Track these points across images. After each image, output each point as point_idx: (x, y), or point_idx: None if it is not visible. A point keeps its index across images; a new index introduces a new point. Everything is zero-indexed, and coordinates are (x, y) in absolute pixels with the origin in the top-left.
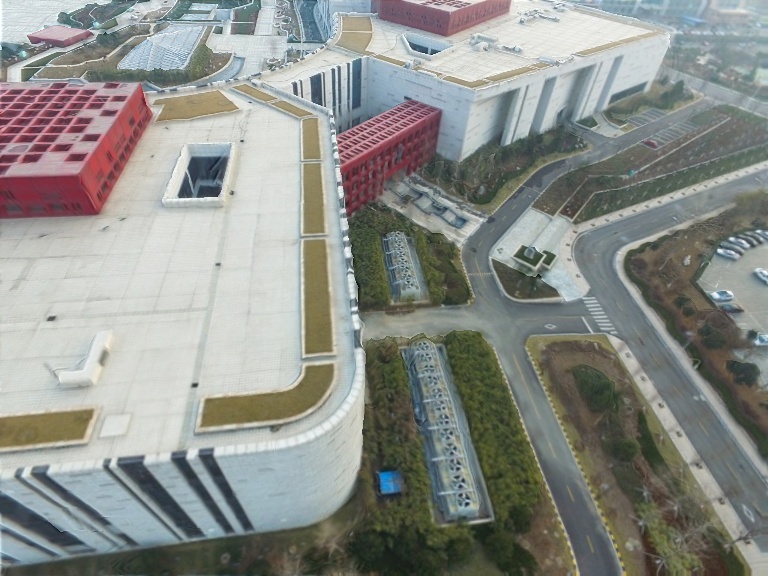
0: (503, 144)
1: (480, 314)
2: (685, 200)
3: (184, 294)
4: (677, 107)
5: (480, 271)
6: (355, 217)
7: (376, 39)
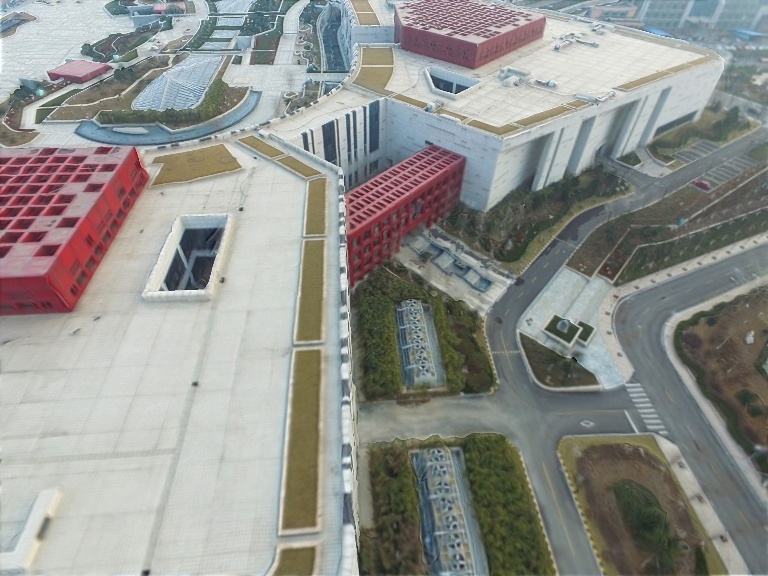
0: (534, 189)
1: (505, 406)
2: (744, 255)
3: (151, 428)
4: (732, 138)
5: (506, 348)
6: (368, 281)
7: (397, 74)
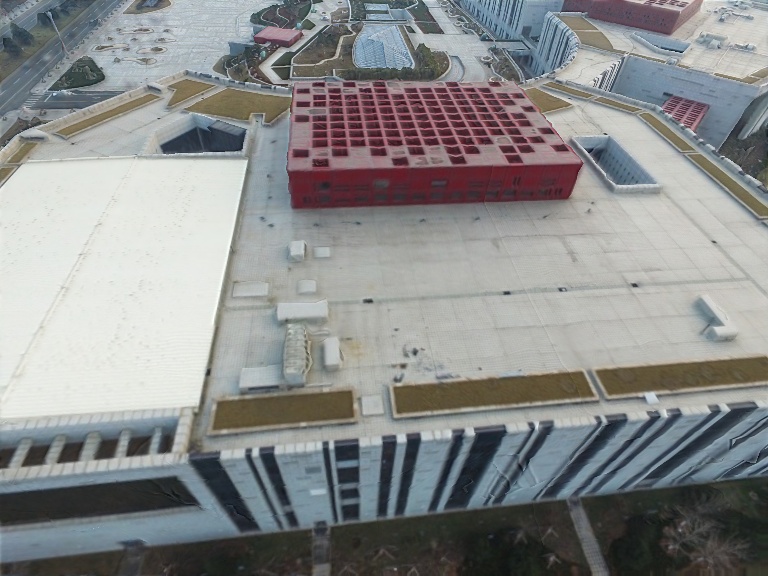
0: (741, 138)
1: None
2: None
3: (716, 266)
4: None
5: None
6: None
7: (609, 38)
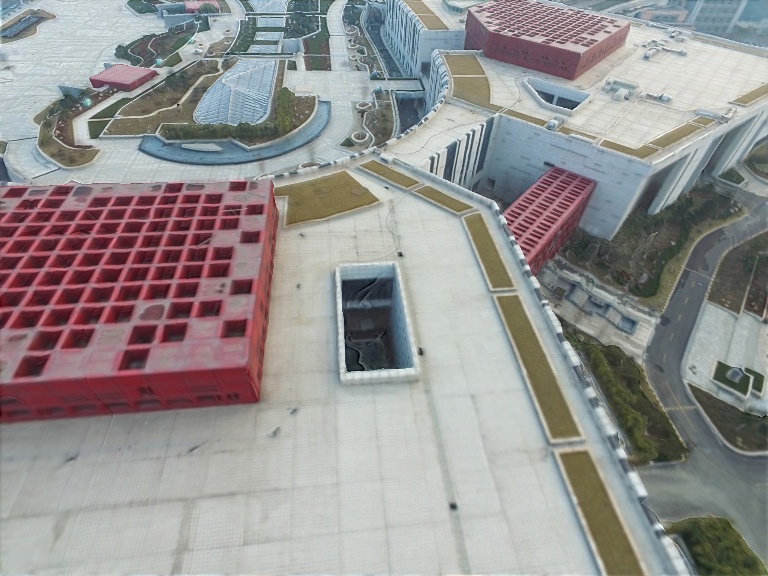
0: (651, 212)
1: (704, 477)
2: None
3: None
4: None
5: (679, 403)
6: None
7: (494, 86)
